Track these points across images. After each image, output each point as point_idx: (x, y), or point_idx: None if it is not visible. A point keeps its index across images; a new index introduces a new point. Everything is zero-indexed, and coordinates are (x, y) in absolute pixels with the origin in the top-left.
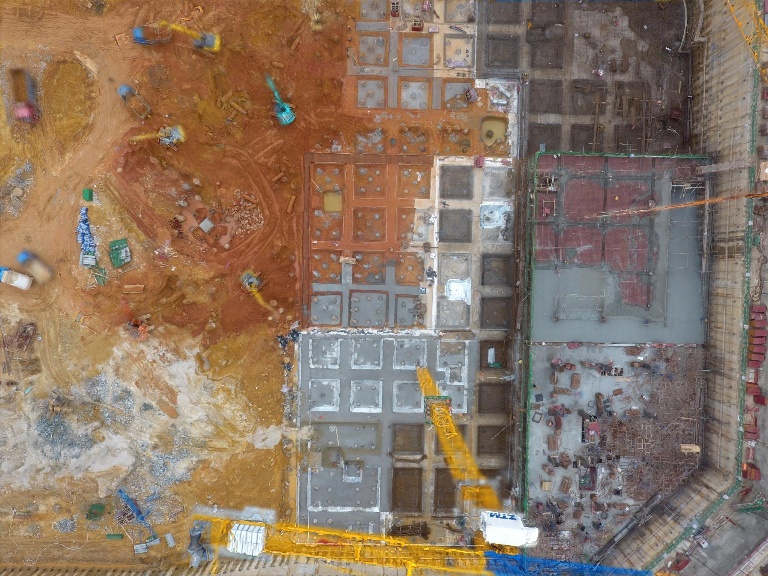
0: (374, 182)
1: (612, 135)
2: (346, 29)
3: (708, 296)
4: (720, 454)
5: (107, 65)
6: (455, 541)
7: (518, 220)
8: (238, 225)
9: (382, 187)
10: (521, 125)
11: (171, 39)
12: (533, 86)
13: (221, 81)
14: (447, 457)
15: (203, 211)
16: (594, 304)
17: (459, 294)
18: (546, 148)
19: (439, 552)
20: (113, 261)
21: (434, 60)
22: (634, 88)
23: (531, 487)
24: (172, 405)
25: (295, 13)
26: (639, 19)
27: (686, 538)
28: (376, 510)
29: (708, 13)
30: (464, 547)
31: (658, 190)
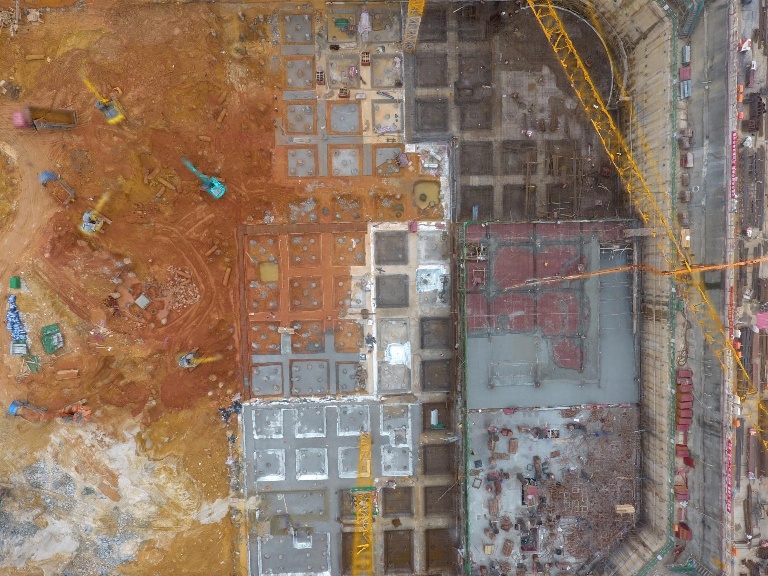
0: (309, 251)
1: (544, 194)
2: (272, 99)
3: (640, 356)
4: (655, 513)
5: (27, 150)
6: None
7: (454, 283)
8: (175, 299)
9: (317, 255)
10: (453, 188)
11: (91, 121)
12: (464, 148)
13: (146, 159)
14: (395, 519)
15: (138, 287)
16: (528, 370)
17: (400, 357)
18: (479, 210)
19: None
20: (45, 348)
21: (363, 126)
22: (564, 147)
23: (474, 551)
24: (114, 488)
25: (219, 86)
26: (566, 77)
27: None
28: (327, 574)
29: (632, 72)
30: None
31: (587, 254)
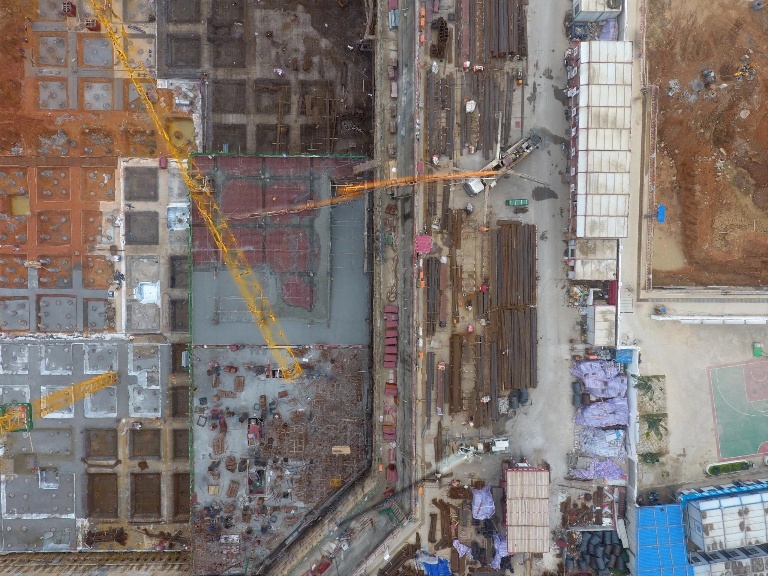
0: (60, 185)
1: (298, 135)
2: (23, 30)
3: (371, 296)
4: None
5: None
6: (153, 546)
7: None
8: None
9: (68, 190)
10: (204, 125)
11: None
12: (218, 86)
13: None
14: (141, 462)
15: None
16: None
17: (153, 297)
18: (229, 148)
19: (130, 558)
20: None
21: (114, 60)
22: (317, 87)
23: (199, 491)
24: None
25: None
26: (320, 17)
27: (332, 541)
28: (72, 516)
29: None
30: (161, 552)
31: (317, 190)
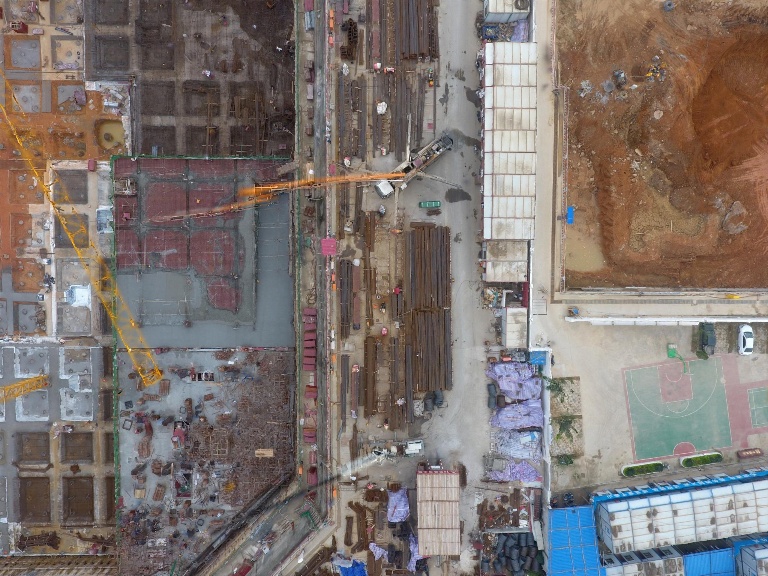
0: None
1: (228, 136)
2: None
3: None
4: None
5: None
6: (86, 550)
7: None
8: None
9: None
10: (132, 128)
11: None
12: (147, 88)
13: None
14: (74, 465)
15: None
16: (177, 309)
17: (85, 300)
18: (158, 151)
19: (62, 562)
20: None
21: (42, 63)
22: (246, 89)
23: (125, 495)
24: None
25: None
26: (248, 18)
27: (254, 544)
28: (5, 521)
29: None
30: (94, 556)
31: (241, 192)
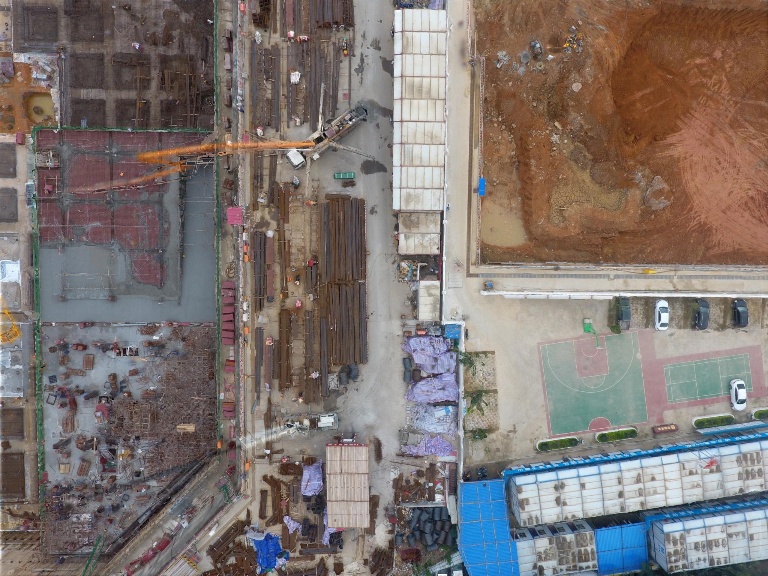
0: None
1: (159, 111)
2: None
3: None
4: None
5: None
6: (18, 526)
7: None
8: None
9: None
10: (61, 101)
11: None
12: (76, 60)
13: None
14: (4, 442)
15: None
16: (101, 283)
17: (16, 275)
18: (88, 124)
19: None
20: None
21: None
22: (177, 62)
23: (50, 470)
24: None
25: None
26: None
27: (174, 518)
28: None
29: None
30: (25, 532)
31: None
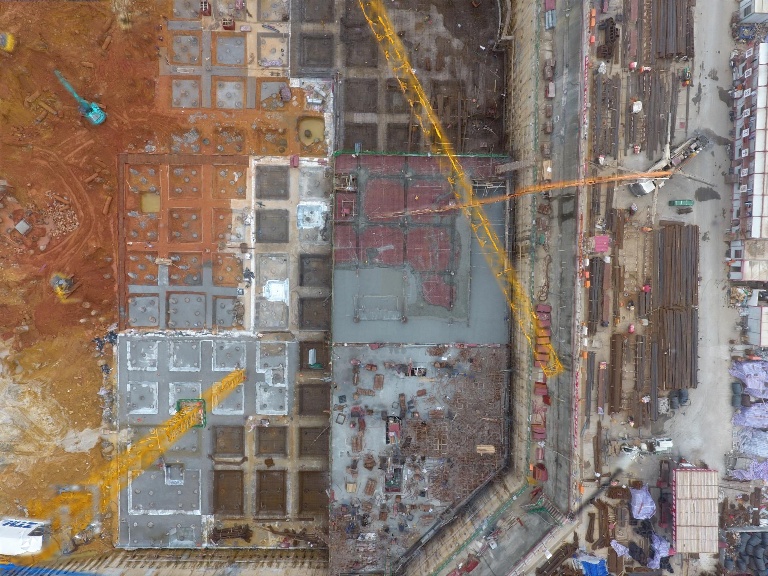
0: (191, 182)
1: (429, 134)
2: (158, 28)
3: (511, 296)
4: (517, 454)
5: None
6: (278, 543)
7: None
8: (56, 226)
9: (199, 187)
10: (336, 124)
11: None
12: (349, 85)
13: (26, 81)
14: (268, 459)
15: (20, 213)
16: (394, 304)
17: (280, 295)
18: None
19: (258, 555)
20: None
21: (248, 59)
22: (449, 87)
23: (336, 489)
24: None
25: (104, 12)
26: (453, 17)
27: (478, 539)
28: (198, 513)
29: (515, 11)
30: (286, 549)
31: (459, 189)
